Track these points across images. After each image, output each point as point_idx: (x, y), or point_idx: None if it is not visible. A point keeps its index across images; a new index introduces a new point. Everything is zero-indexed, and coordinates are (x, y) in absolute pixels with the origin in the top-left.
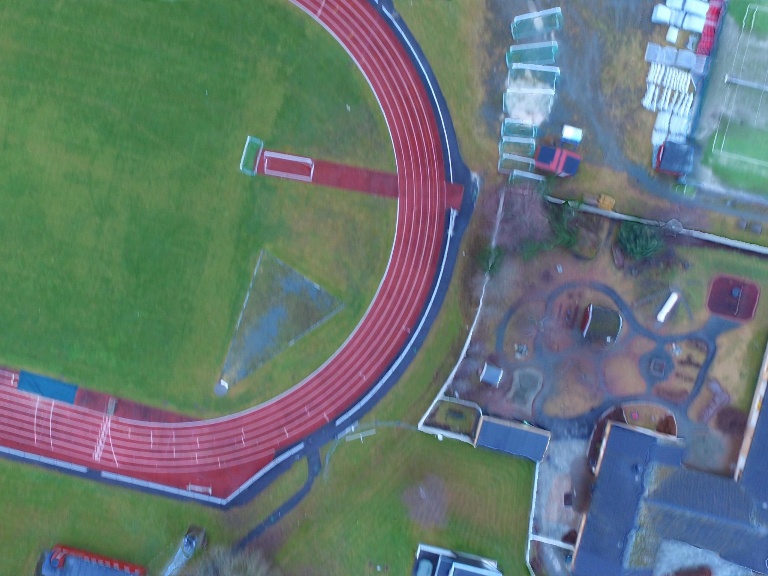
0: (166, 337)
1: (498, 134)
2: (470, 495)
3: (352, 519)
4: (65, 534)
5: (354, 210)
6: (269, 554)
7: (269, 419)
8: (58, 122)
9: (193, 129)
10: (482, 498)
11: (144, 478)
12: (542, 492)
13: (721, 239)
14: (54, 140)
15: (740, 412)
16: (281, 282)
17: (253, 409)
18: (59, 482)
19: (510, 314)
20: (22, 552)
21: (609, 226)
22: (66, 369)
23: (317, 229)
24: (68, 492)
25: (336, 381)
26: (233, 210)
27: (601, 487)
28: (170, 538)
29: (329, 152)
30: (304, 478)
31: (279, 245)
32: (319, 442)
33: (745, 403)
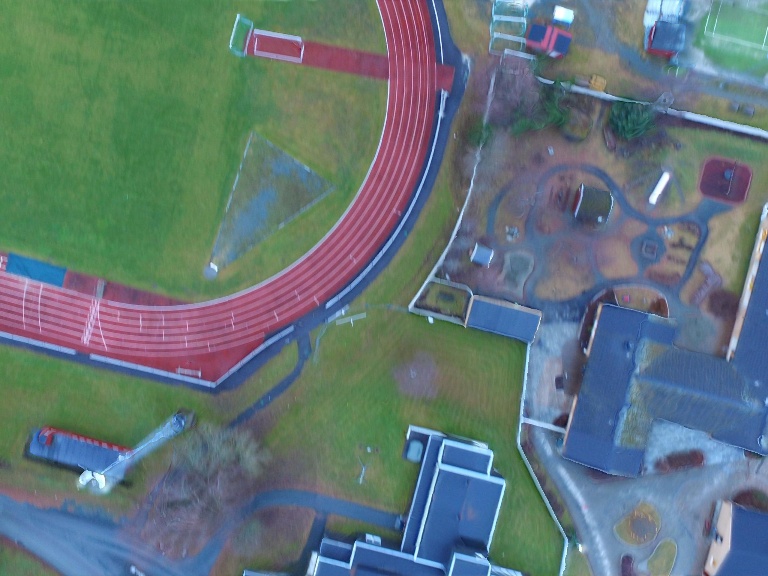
0: (155, 219)
1: (489, 15)
2: (461, 379)
3: (342, 401)
4: (53, 416)
5: (344, 92)
6: (259, 435)
7: (259, 302)
8: (47, 2)
9: (182, 9)
10: (473, 382)
11: (133, 361)
12: (533, 375)
13: (713, 120)
14: (43, 20)
15: (732, 294)
16: (271, 164)
17: (243, 292)
18: (48, 365)
19: (501, 196)
20: (10, 433)
21: (601, 108)
22: (55, 252)
23: (307, 111)
24: (57, 375)
25: (326, 264)
26: (223, 91)
27: (592, 366)
28: (159, 421)
29: (319, 33)
30: (294, 362)
31: (269, 127)
32: (309, 326)
33: (737, 286)
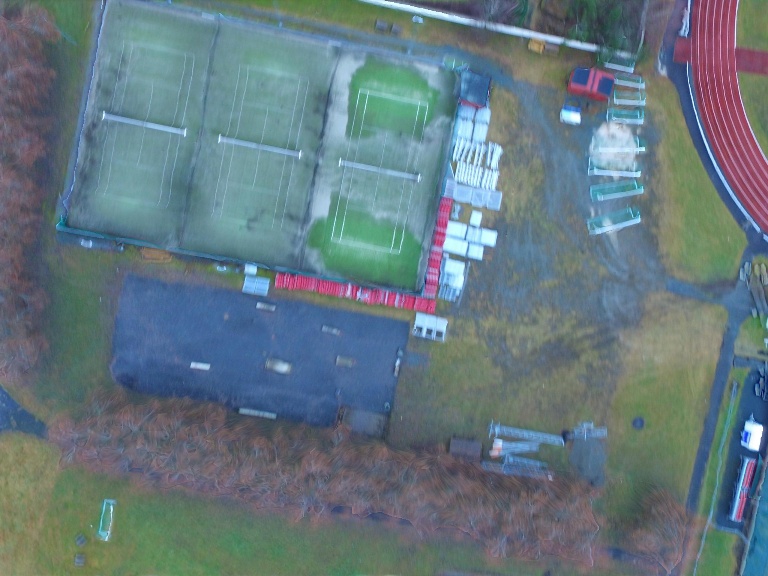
0: None
1: None
2: None
3: None
4: None
5: None
6: None
7: None
8: None
9: None
10: None
11: None
12: None
13: (420, 11)
14: None
15: None
16: None
17: None
18: None
19: None
20: None
21: (531, 24)
22: None
23: None
24: None
25: None
26: None
27: None
28: None
29: None
30: None
31: None
32: None
33: None
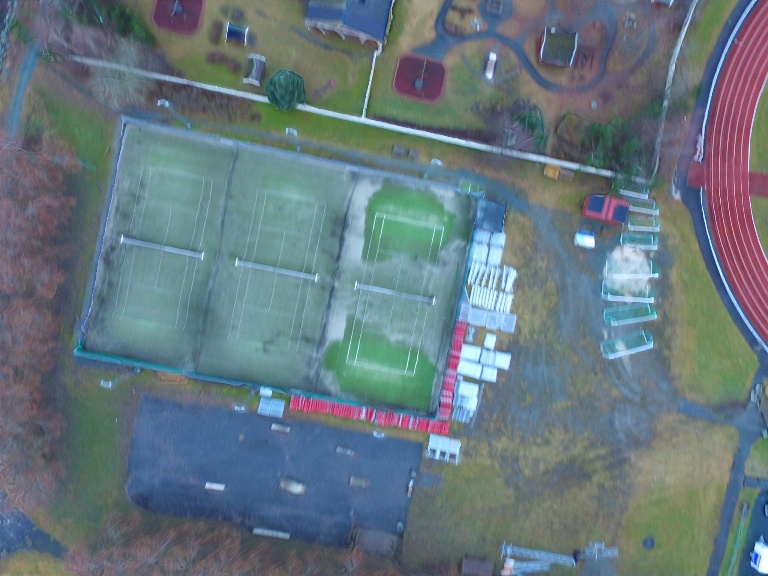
0: None
1: None
2: None
3: None
4: None
5: None
6: None
7: None
8: None
9: None
10: None
11: None
12: None
13: (437, 138)
14: None
15: None
16: None
17: None
18: None
19: (644, 58)
20: None
21: (547, 149)
22: None
23: None
24: None
25: None
26: None
27: None
28: None
29: None
30: None
31: None
32: None
33: None
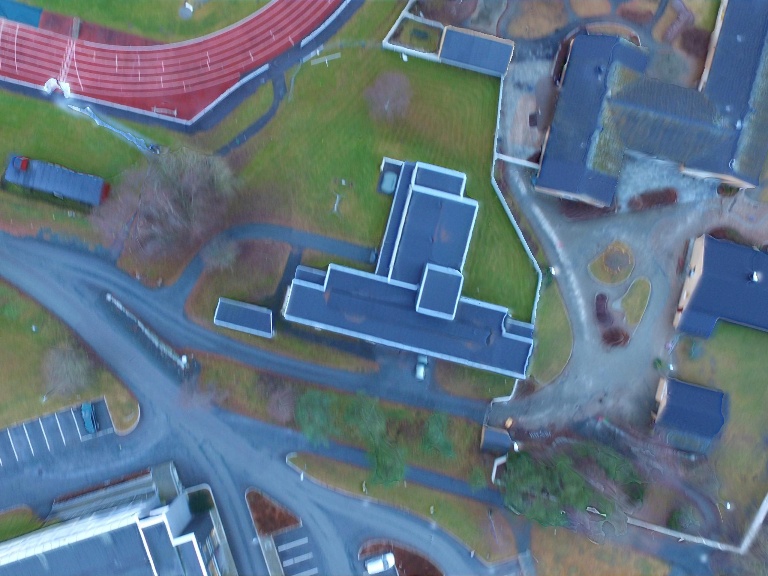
0: None
1: None
2: (435, 117)
3: (317, 137)
4: (30, 151)
5: None
6: (234, 167)
7: (234, 43)
8: None
9: None
10: (447, 120)
11: (109, 99)
12: (507, 114)
13: None
14: None
15: (704, 31)
16: None
17: (218, 32)
18: (24, 105)
19: None
20: None
21: None
22: None
23: None
24: (33, 114)
25: (301, 4)
26: None
27: (565, 95)
28: (135, 157)
29: None
30: (269, 102)
31: None
32: (284, 65)
33: (709, 23)
